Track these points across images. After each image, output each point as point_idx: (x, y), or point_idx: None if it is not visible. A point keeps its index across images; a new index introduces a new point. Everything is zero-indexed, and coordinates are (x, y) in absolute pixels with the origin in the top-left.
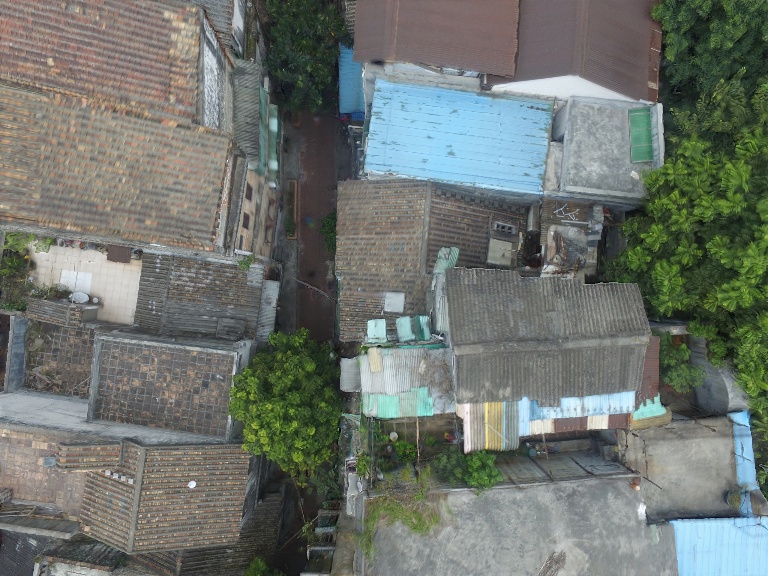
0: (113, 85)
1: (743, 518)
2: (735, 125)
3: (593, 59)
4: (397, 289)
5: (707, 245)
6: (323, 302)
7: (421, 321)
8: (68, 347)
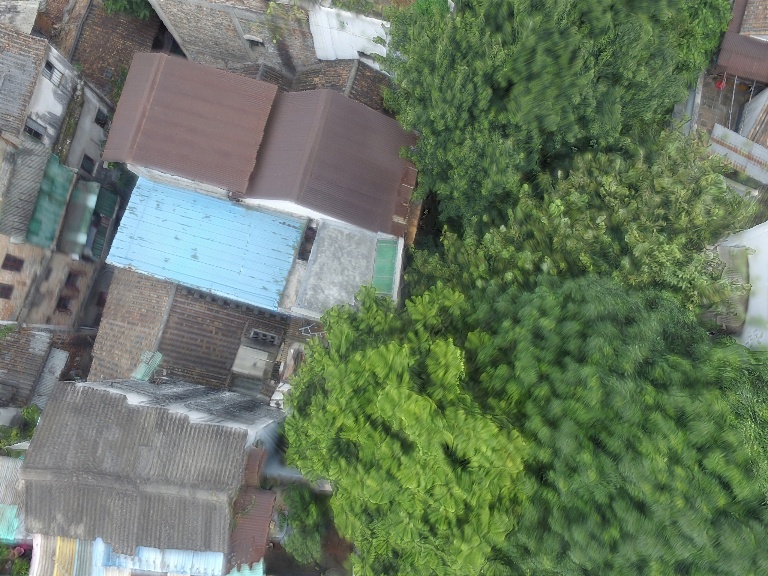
0: None
1: None
2: (452, 272)
3: (317, 188)
4: None
5: None
6: None
7: None
8: None
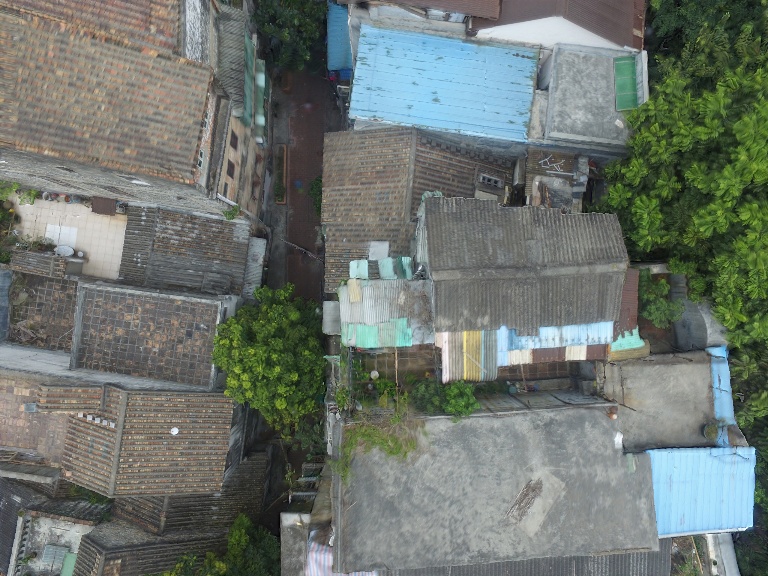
0: (92, 12)
1: (719, 448)
2: (718, 69)
3: (577, 1)
4: (382, 238)
5: (685, 173)
6: (312, 268)
7: (403, 262)
8: (53, 301)
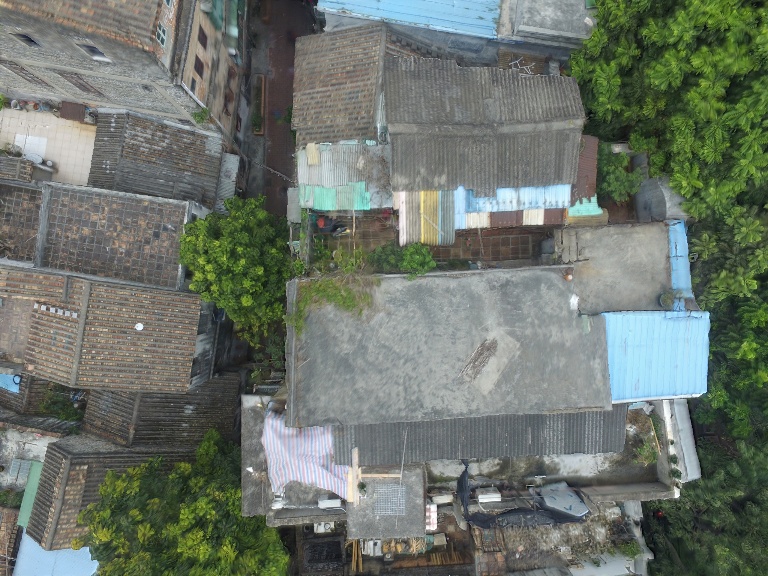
0: None
1: (674, 311)
2: None
3: None
4: (351, 138)
5: (643, 32)
6: None
7: None
8: (21, 212)
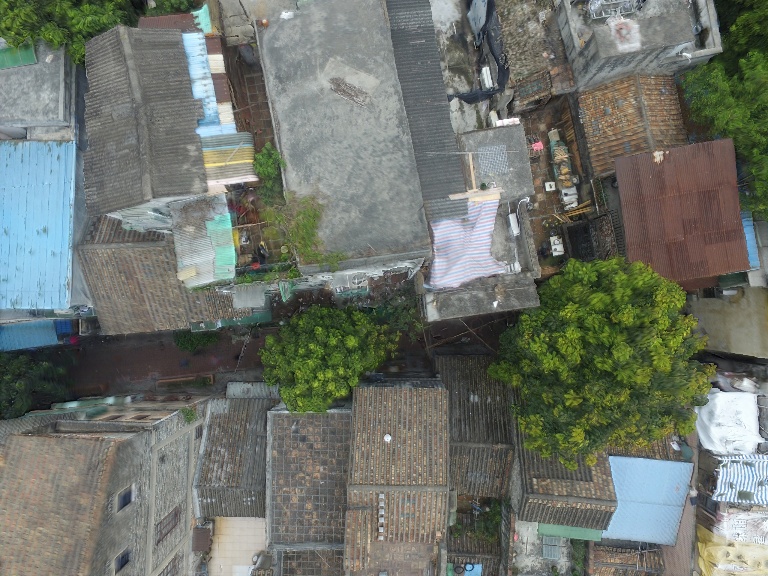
0: None
1: None
2: None
3: None
4: None
5: None
6: None
7: None
8: None
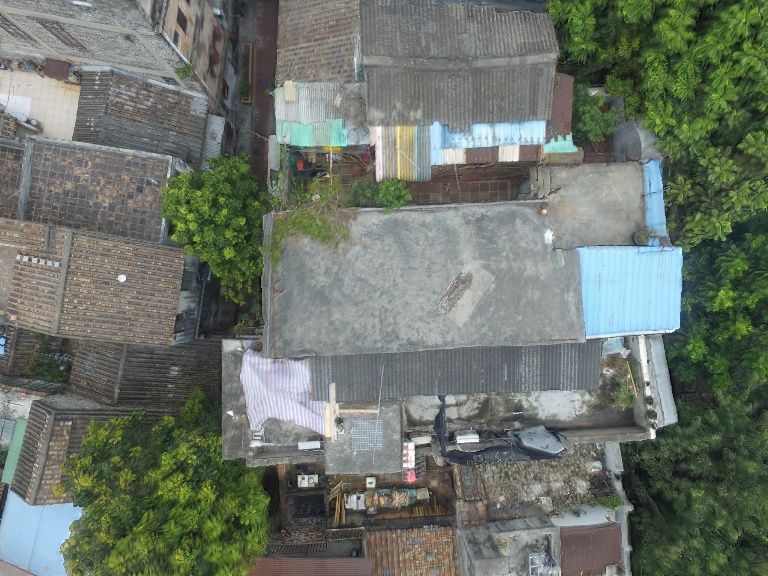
0: None
1: (647, 247)
2: None
3: None
4: None
5: None
6: None
7: None
8: (6, 171)
